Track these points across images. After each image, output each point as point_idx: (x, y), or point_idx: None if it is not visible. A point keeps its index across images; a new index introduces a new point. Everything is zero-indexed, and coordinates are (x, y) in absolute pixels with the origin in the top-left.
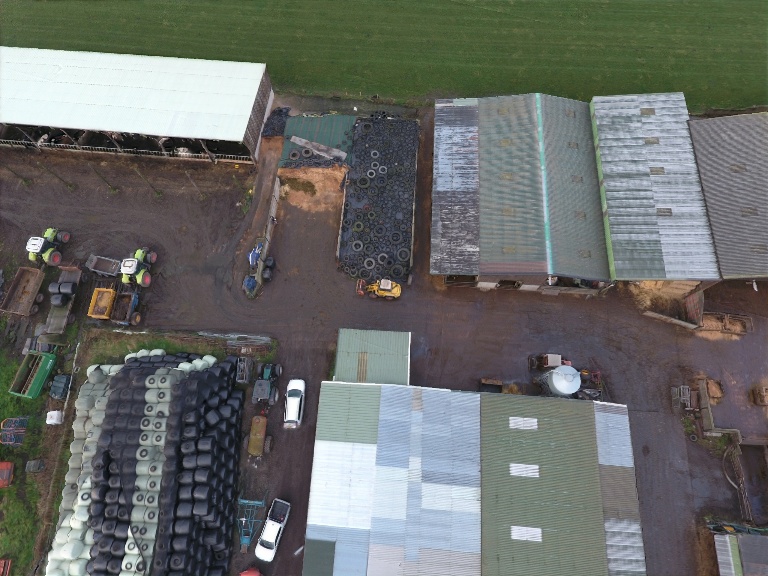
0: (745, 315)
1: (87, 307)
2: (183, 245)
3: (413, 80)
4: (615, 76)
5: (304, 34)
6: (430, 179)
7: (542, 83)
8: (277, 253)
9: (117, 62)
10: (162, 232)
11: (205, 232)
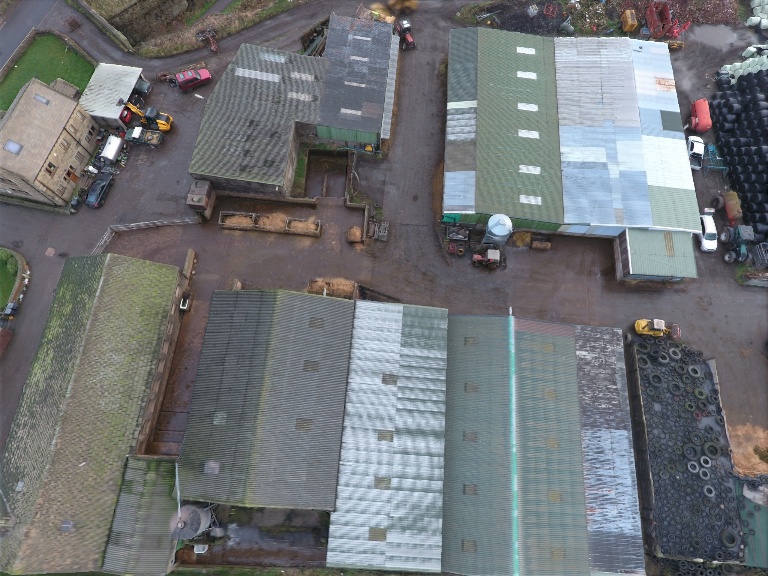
0: (311, 293)
1: None
2: None
3: None
4: None
5: None
6: None
7: None
8: None
9: None
10: None
11: None
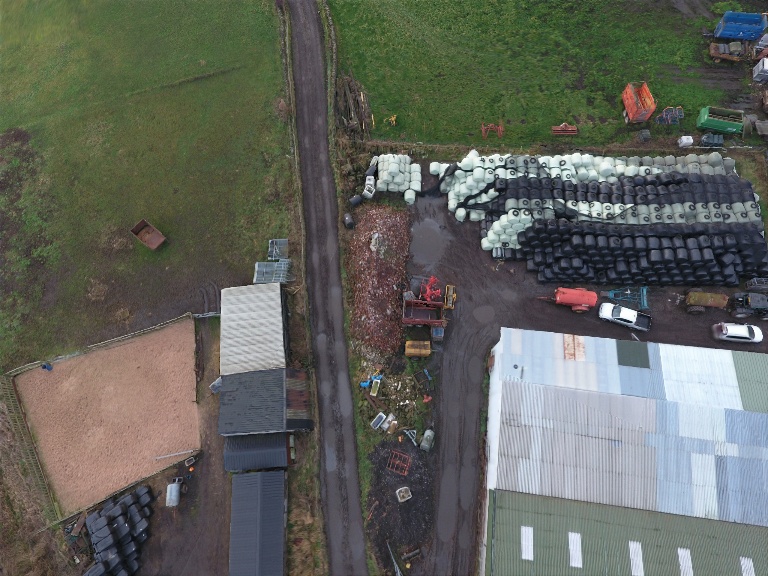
0: None
1: None
2: None
3: None
4: None
5: None
6: None
7: None
8: None
9: None
10: None
11: None
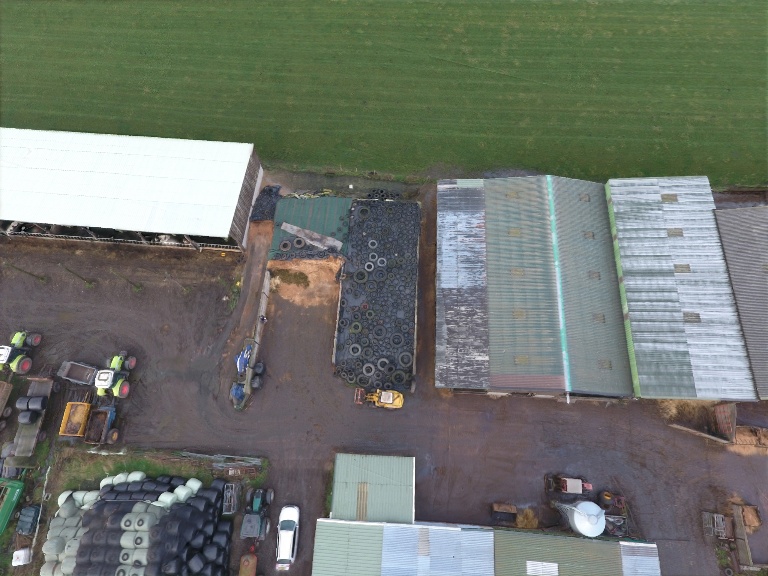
0: None
1: (59, 421)
2: (165, 347)
3: (413, 153)
4: (630, 147)
5: (295, 101)
6: (433, 267)
7: (552, 155)
8: (267, 355)
9: (92, 143)
10: (142, 332)
11: (189, 331)
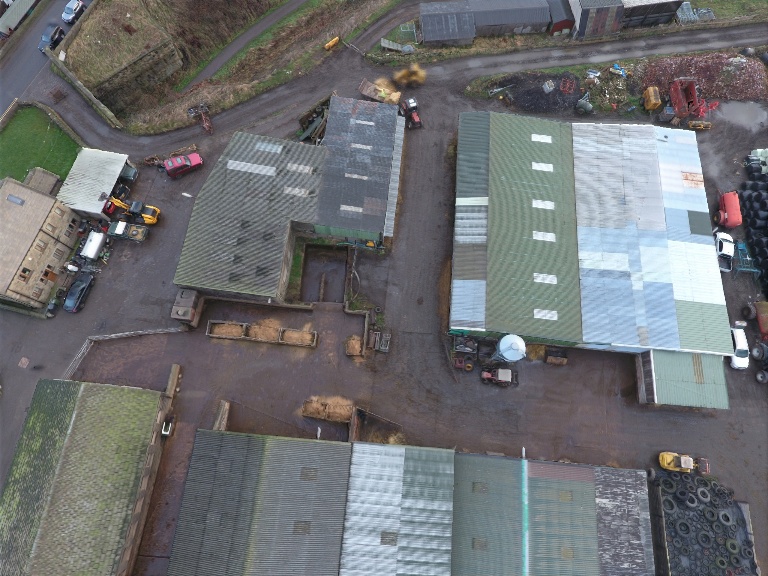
0: None
1: None
2: None
3: None
4: None
5: None
6: None
7: None
8: None
9: None
10: None
11: None
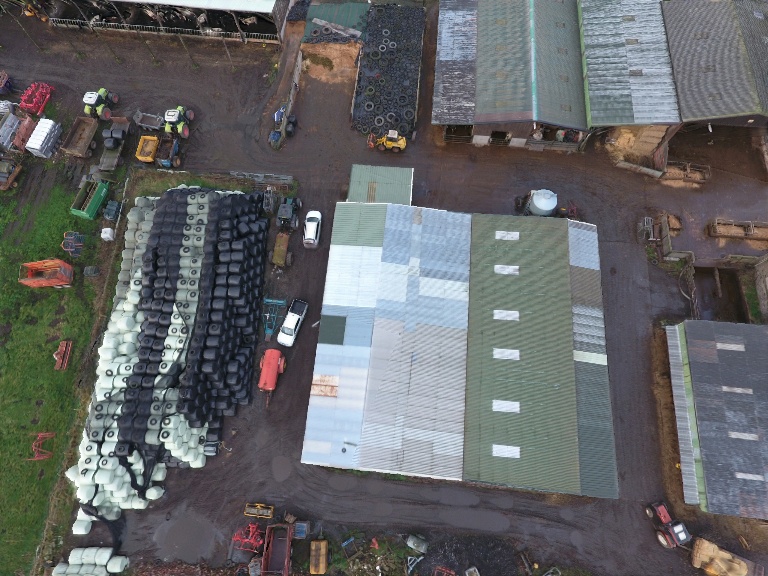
0: (704, 165)
1: (134, 154)
2: (217, 107)
3: None
4: None
5: None
6: (434, 59)
7: None
8: (299, 115)
9: None
10: (198, 97)
11: (236, 97)
